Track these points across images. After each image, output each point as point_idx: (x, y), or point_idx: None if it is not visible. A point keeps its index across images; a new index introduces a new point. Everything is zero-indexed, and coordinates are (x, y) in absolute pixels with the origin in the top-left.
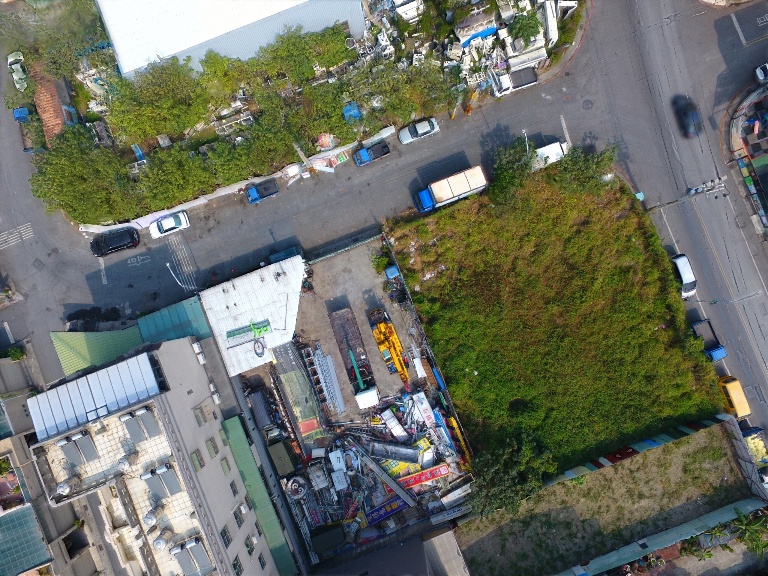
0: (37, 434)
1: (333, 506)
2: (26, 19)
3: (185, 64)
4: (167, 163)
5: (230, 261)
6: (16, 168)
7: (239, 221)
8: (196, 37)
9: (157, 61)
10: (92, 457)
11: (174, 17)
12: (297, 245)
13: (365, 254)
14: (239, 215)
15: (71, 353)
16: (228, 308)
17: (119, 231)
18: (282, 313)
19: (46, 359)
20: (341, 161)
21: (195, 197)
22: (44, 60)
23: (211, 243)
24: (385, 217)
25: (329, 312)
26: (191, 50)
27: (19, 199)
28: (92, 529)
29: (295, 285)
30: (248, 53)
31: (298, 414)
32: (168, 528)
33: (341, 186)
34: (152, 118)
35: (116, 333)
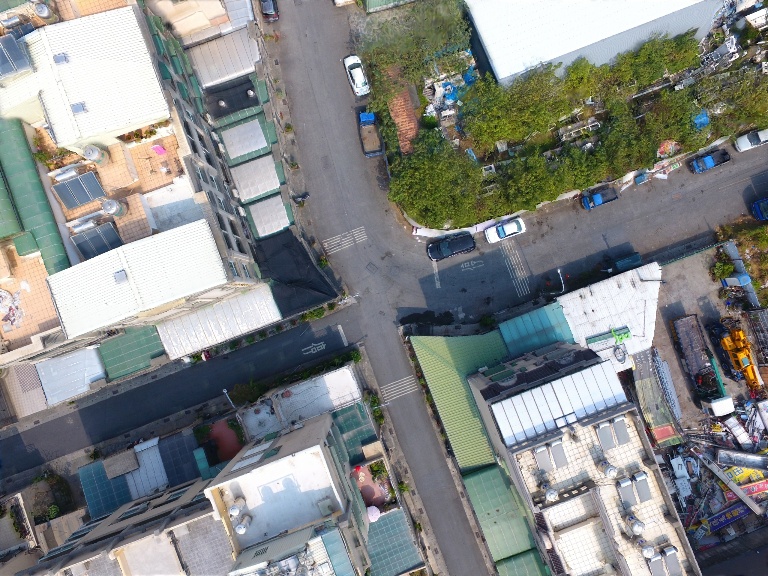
0: (505, 440)
1: (682, 513)
2: (358, 23)
3: (552, 70)
4: (537, 169)
5: (563, 267)
6: (349, 172)
7: (572, 227)
8: (571, 44)
9: (533, 67)
10: (562, 464)
11: (547, 23)
12: (632, 251)
13: (699, 261)
14: (572, 221)
15: (433, 357)
16: (586, 314)
17: (462, 236)
18: (640, 320)
19: (380, 362)
20: (674, 168)
21: (537, 203)
22: (397, 65)
23: (544, 248)
24: (718, 224)
25: (664, 319)
26: (567, 56)
27: (353, 203)
28: (427, 532)
29: (652, 292)
30: (604, 60)
31: (650, 421)
32: (638, 535)
33: (674, 193)
34: (526, 124)
35: (477, 338)
